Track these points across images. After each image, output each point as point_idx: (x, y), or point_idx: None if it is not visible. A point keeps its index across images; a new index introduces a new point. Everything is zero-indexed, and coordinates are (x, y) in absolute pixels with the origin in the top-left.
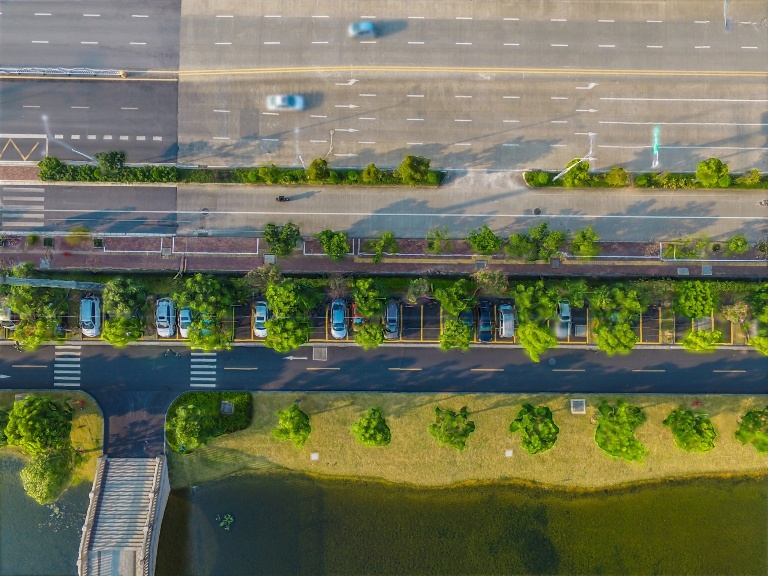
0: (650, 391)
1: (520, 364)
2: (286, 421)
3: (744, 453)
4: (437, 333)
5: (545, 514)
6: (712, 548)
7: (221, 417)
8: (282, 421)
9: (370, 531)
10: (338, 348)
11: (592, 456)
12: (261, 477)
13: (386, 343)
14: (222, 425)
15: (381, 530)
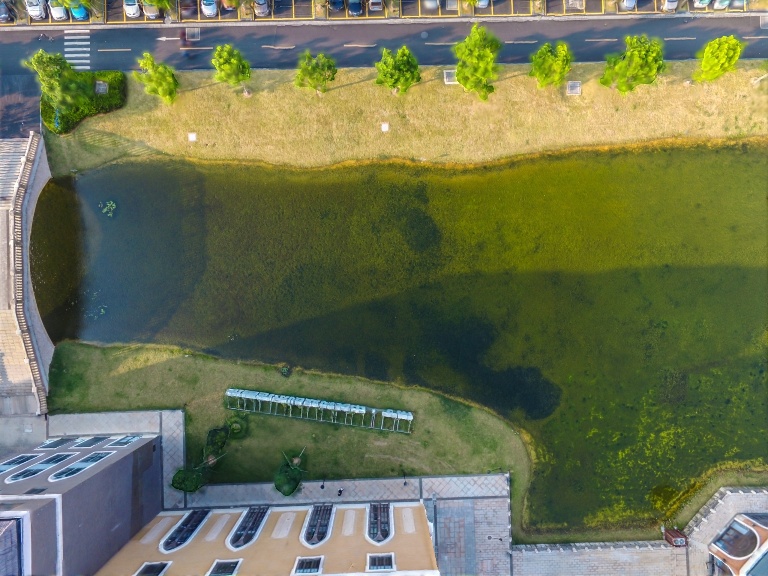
0: (522, 60)
1: (392, 38)
2: (146, 63)
3: (619, 121)
4: (309, 10)
5: (426, 193)
6: (592, 221)
7: (95, 95)
8: (142, 64)
9: (253, 214)
10: (211, 28)
11: (467, 127)
12: (142, 164)
13: (258, 22)
14: (97, 103)
15: (263, 213)
